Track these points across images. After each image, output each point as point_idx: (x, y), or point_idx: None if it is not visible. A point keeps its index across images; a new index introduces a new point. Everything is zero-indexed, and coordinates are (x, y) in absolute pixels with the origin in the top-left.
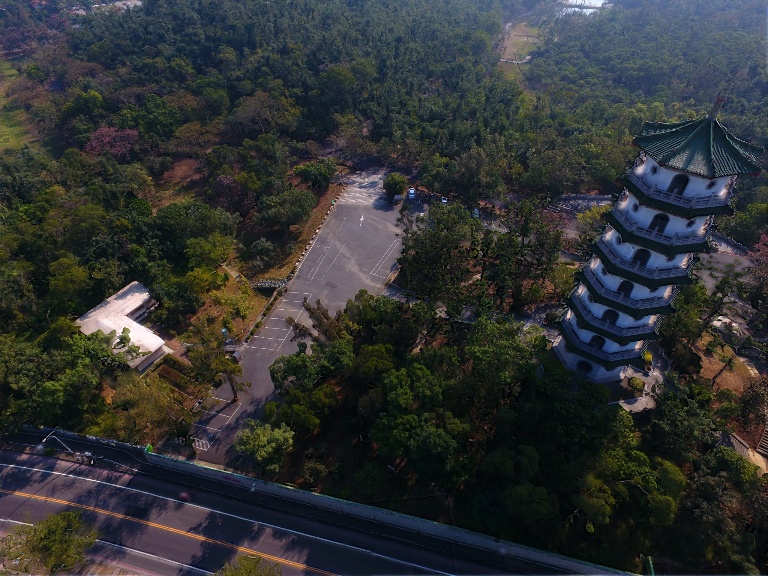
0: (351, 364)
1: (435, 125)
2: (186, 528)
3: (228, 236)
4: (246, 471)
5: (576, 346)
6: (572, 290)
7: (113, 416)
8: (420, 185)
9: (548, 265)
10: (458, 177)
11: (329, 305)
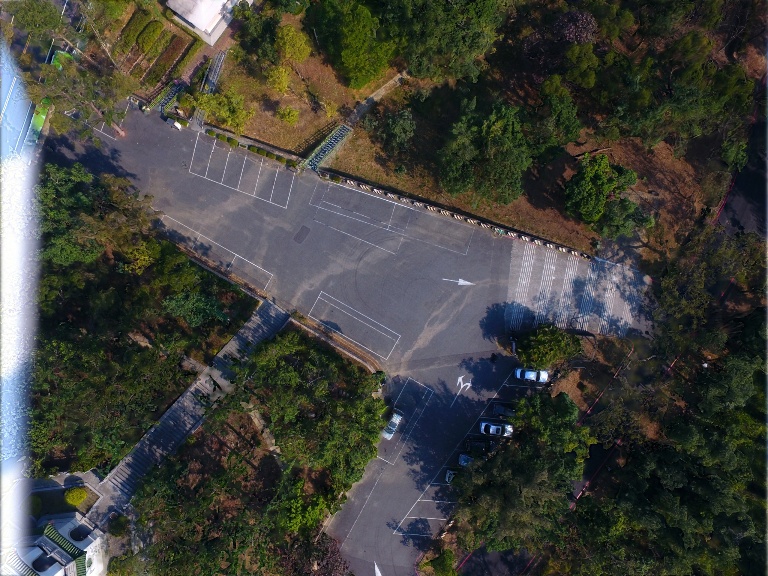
0: (29, 259)
1: (719, 456)
2: (7, 112)
3: (432, 68)
4: (40, 157)
5: (2, 540)
6: (27, 570)
7: (121, 5)
8: (587, 393)
9: (233, 557)
10: (467, 467)
11: (262, 232)
